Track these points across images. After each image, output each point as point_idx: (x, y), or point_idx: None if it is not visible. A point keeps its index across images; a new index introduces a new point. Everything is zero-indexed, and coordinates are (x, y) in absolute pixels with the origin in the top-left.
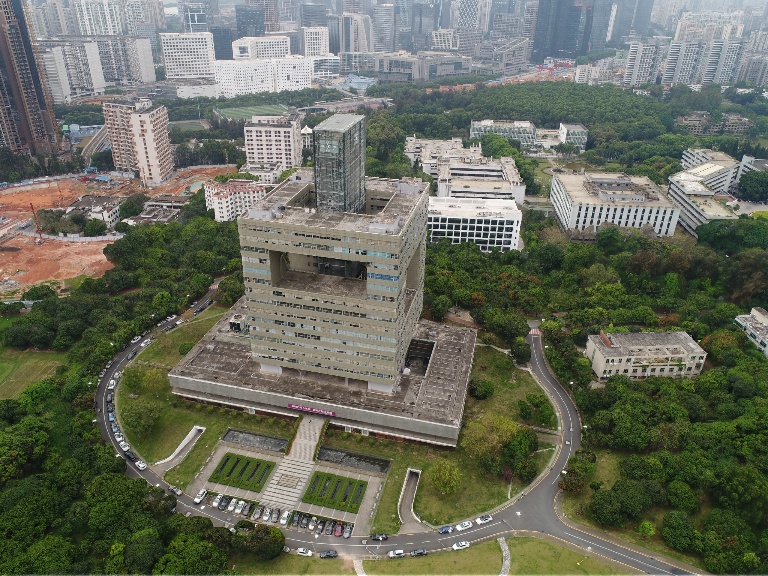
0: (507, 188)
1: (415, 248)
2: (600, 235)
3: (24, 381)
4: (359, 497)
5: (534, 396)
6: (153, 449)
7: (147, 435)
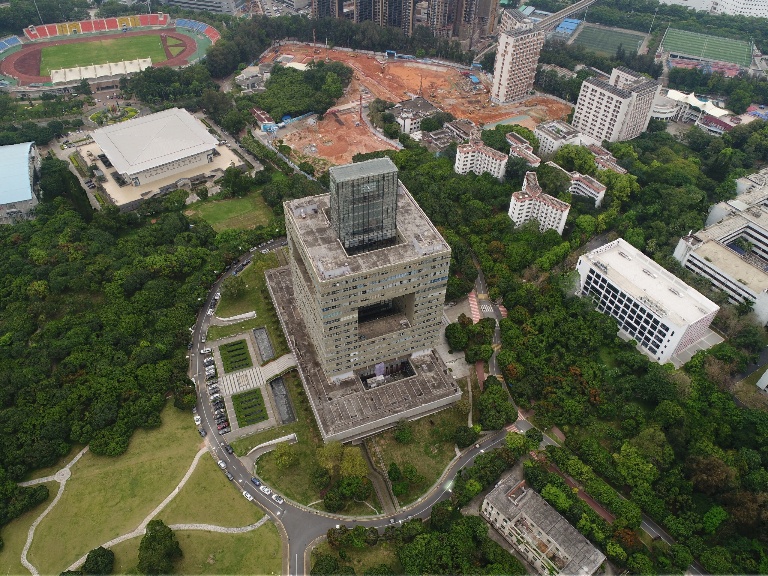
0: (759, 289)
1: (391, 295)
2: (747, 412)
3: (243, 222)
4: (253, 421)
5: (412, 471)
6: (225, 308)
7: (233, 298)
